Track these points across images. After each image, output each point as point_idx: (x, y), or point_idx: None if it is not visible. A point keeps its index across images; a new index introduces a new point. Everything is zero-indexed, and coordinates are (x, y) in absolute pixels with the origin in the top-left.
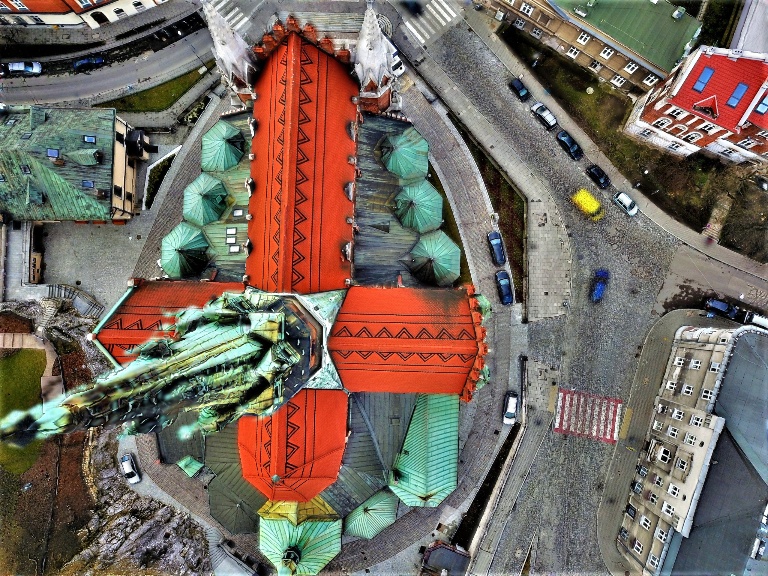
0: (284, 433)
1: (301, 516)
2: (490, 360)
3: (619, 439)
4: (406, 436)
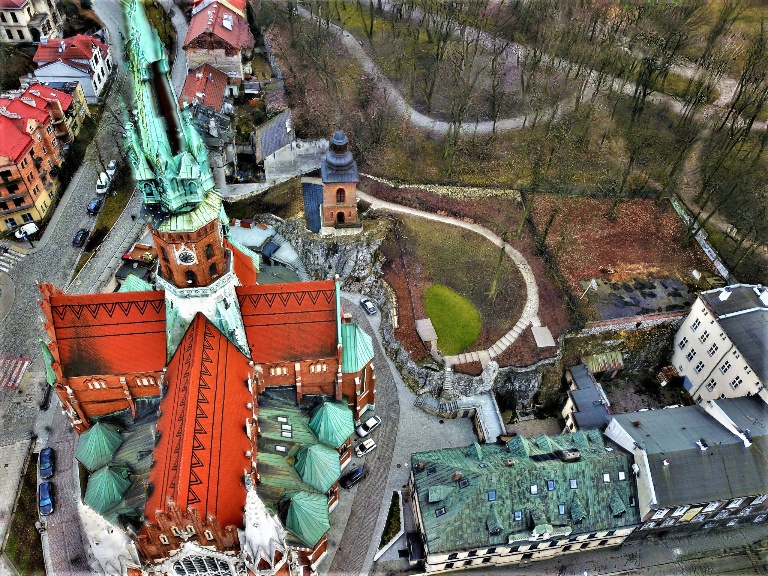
0: None
1: None
2: None
3: None
4: None
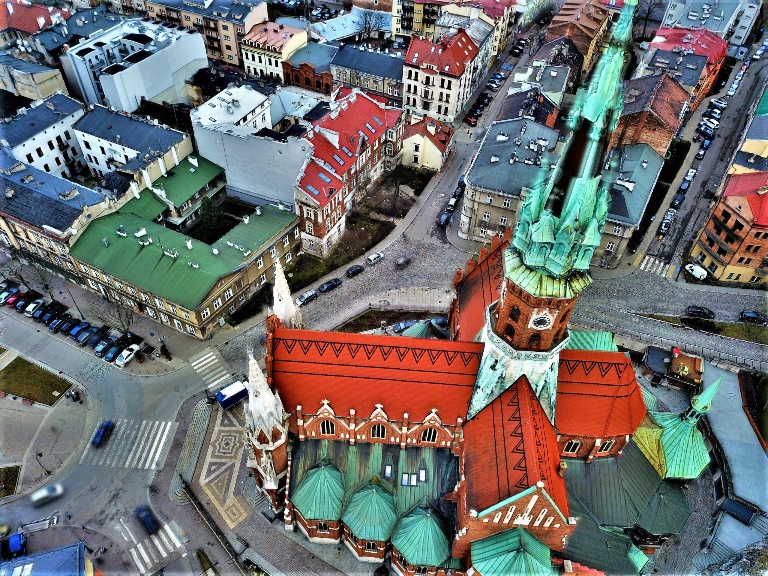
0: None
1: None
2: None
3: None
4: None
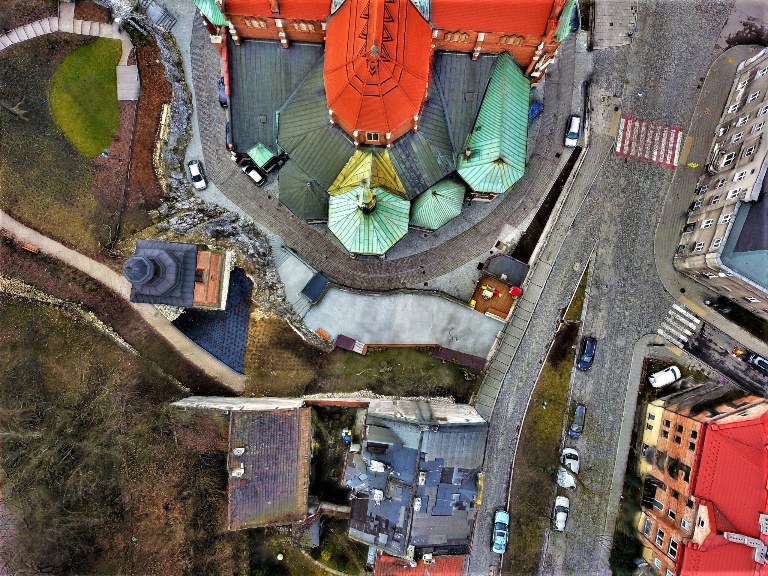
0: (382, 12)
1: (374, 182)
2: (554, 85)
3: (679, 164)
4: (478, 113)
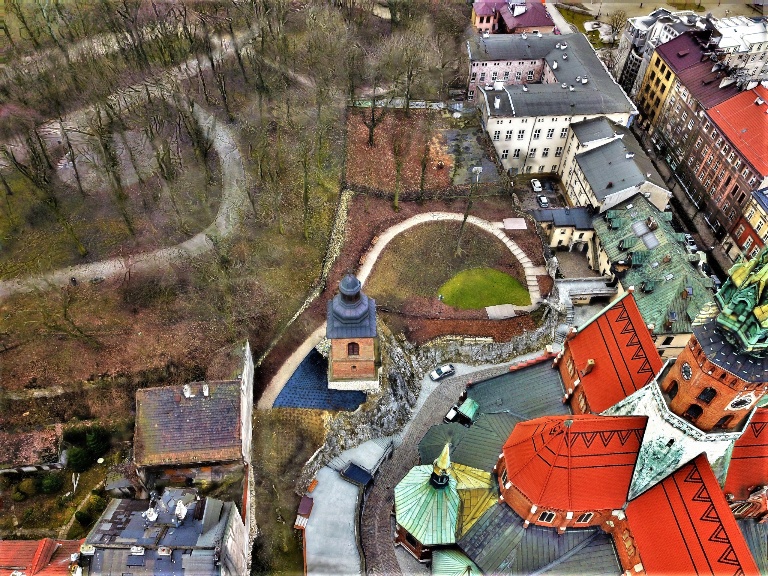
0: (606, 428)
1: (464, 494)
2: None
3: None
4: None
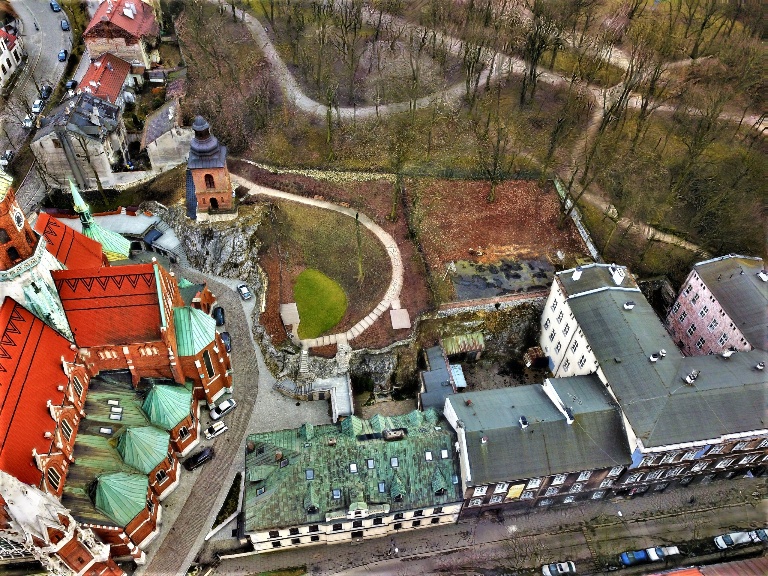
0: None
1: None
2: None
3: None
4: None
